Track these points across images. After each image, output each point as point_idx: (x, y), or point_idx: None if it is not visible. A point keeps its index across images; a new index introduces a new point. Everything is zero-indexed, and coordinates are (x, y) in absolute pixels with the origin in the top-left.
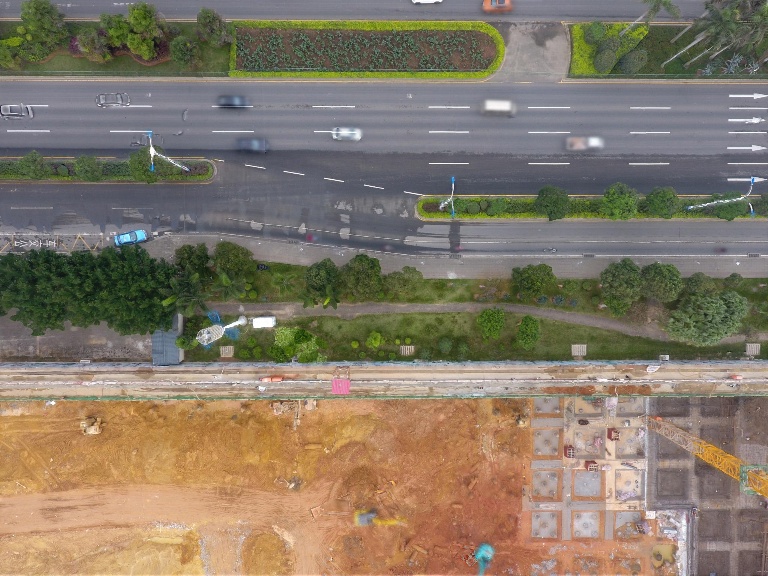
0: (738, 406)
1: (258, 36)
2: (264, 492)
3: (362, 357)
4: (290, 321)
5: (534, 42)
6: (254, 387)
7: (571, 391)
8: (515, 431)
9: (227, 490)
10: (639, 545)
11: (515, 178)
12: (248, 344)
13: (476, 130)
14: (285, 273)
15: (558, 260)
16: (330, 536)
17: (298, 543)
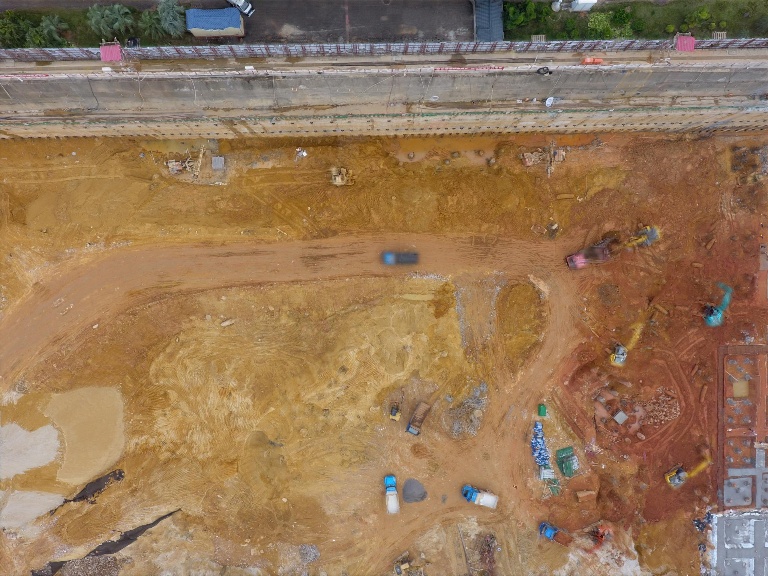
0: None
1: None
2: (520, 241)
3: None
4: (603, 7)
5: None
6: (540, 103)
7: None
8: (753, 188)
9: (483, 239)
10: None
11: None
12: (568, 25)
13: None
14: None
15: None
16: (585, 285)
17: (553, 293)
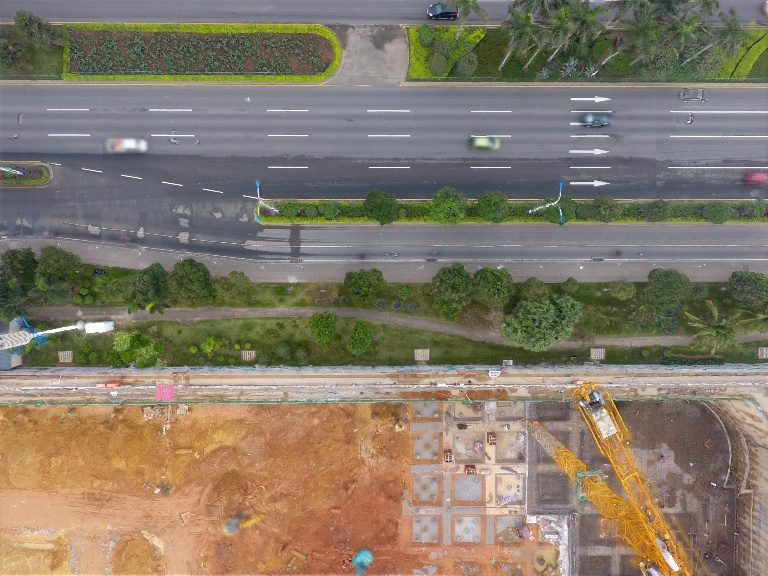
0: None
1: (92, 39)
2: (133, 497)
3: (200, 362)
4: (129, 326)
5: (373, 45)
6: (107, 392)
7: (426, 396)
8: (394, 435)
9: (96, 495)
10: (520, 550)
11: (355, 182)
12: (83, 349)
13: (315, 134)
14: (123, 278)
15: (400, 264)
16: (201, 541)
17: (168, 548)
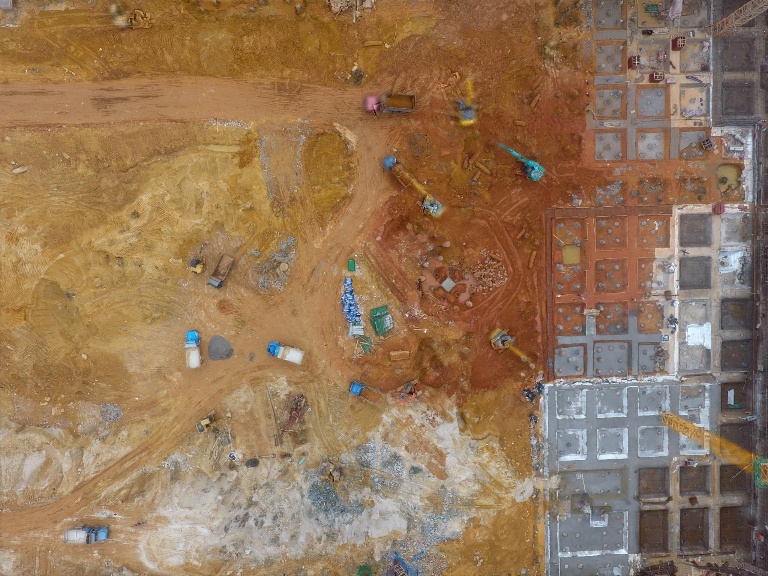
0: None
1: None
2: (324, 87)
3: None
4: None
5: None
6: None
7: None
8: (577, 44)
9: (285, 86)
10: (705, 164)
11: None
12: None
13: None
14: None
15: None
16: (393, 135)
17: (361, 143)
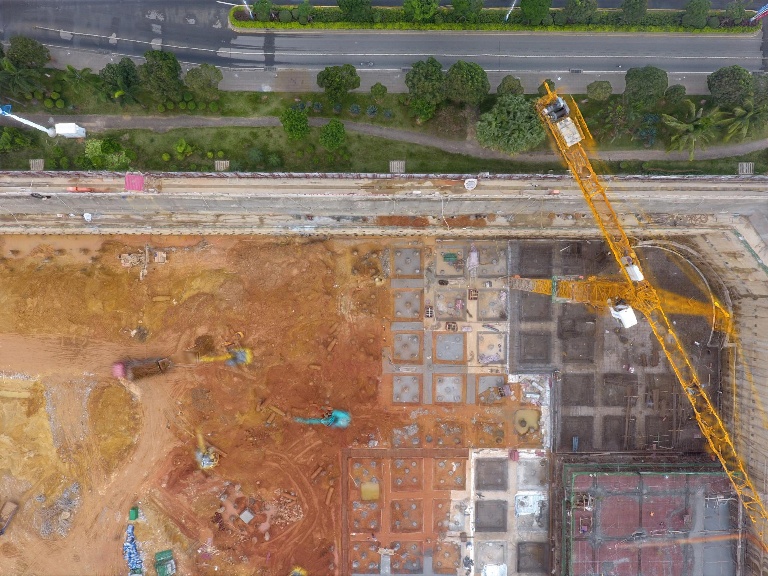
0: (600, 267)
1: None
2: (110, 343)
3: (173, 169)
4: (101, 134)
5: None
6: (80, 217)
7: (403, 223)
8: (374, 291)
9: (72, 340)
10: (501, 409)
11: None
12: (54, 153)
13: None
14: None
15: (375, 74)
16: (178, 389)
17: (145, 396)
